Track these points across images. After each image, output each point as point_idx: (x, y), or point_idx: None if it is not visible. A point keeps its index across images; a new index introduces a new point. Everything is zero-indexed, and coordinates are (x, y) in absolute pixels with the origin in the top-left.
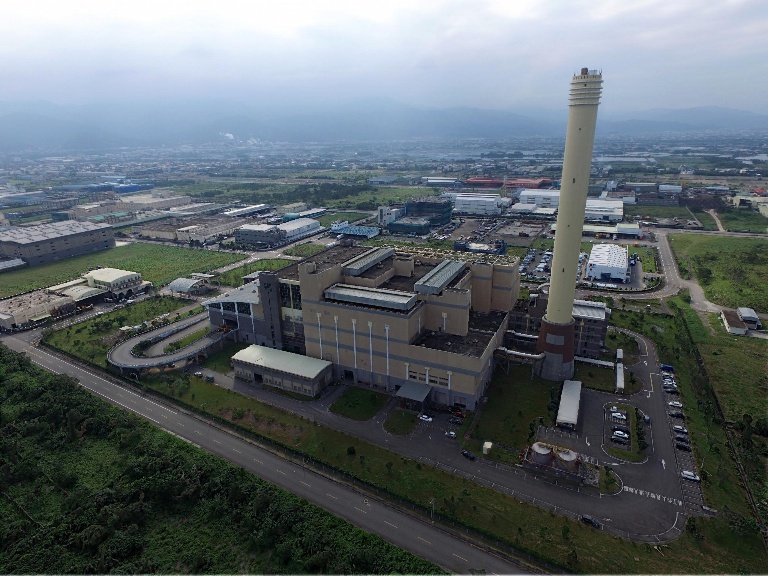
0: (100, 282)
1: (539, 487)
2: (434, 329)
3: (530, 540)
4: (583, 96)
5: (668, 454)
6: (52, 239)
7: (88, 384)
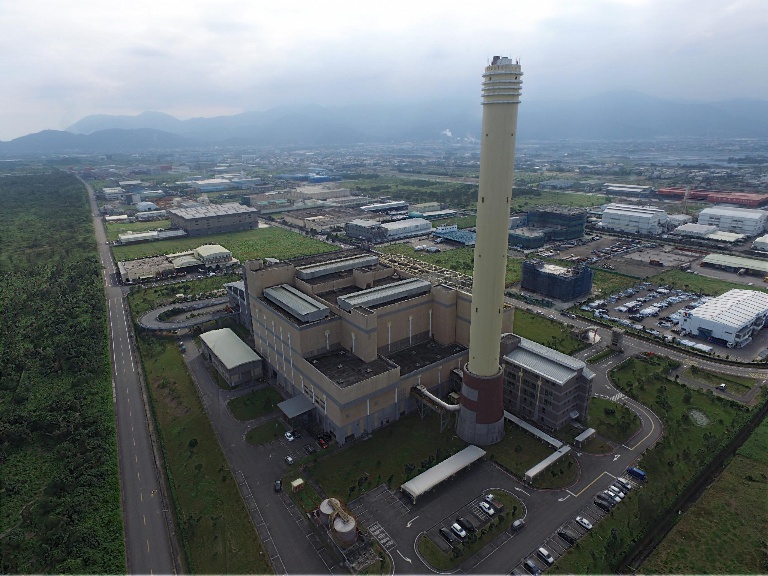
0: (200, 255)
1: (298, 546)
2: (348, 348)
3: None
4: (487, 93)
5: None
6: (208, 217)
7: (115, 333)
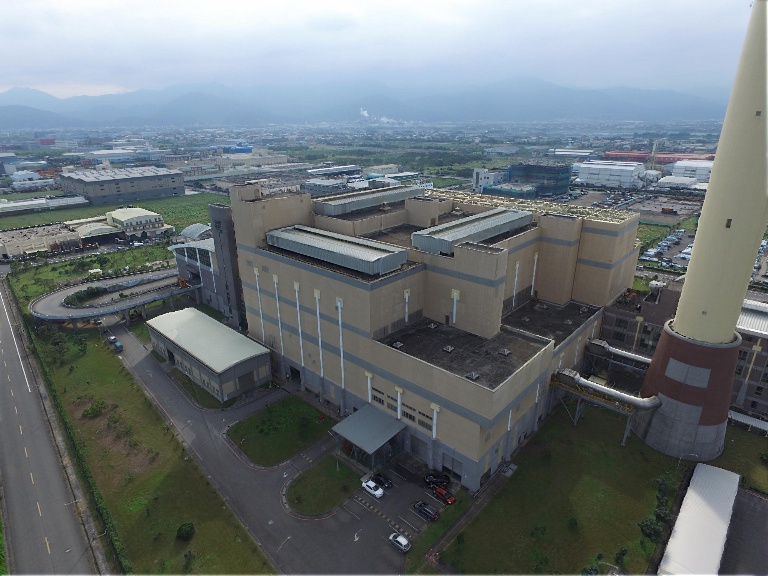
0: (117, 220)
1: None
2: (438, 318)
3: None
4: None
5: None
6: (117, 180)
7: None
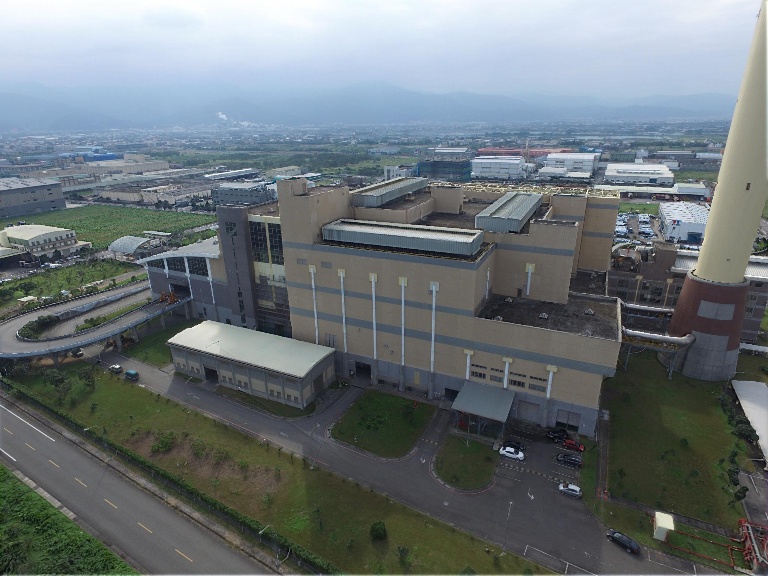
0: (15, 240)
1: None
2: (509, 293)
3: None
4: None
5: None
6: None
7: None
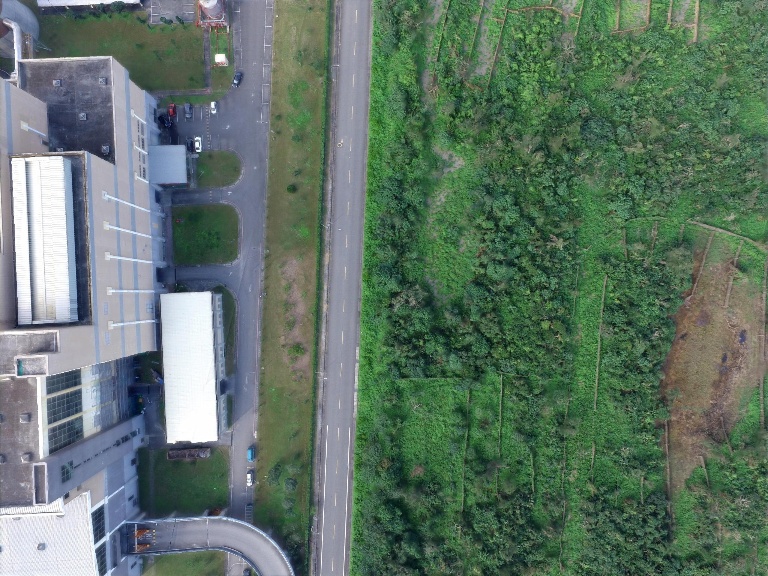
0: None
1: (250, 6)
2: None
3: (315, 1)
4: None
5: None
6: None
7: None
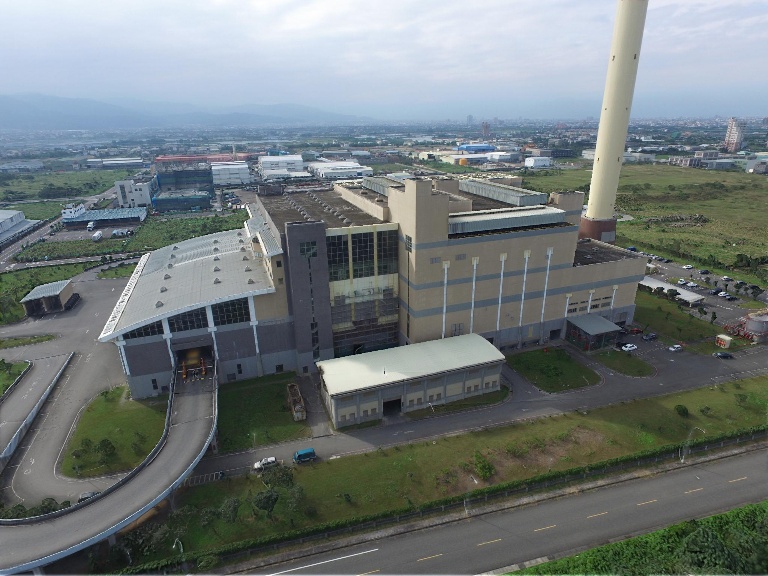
0: None
1: None
2: None
3: None
4: None
5: (760, 294)
6: None
7: None
